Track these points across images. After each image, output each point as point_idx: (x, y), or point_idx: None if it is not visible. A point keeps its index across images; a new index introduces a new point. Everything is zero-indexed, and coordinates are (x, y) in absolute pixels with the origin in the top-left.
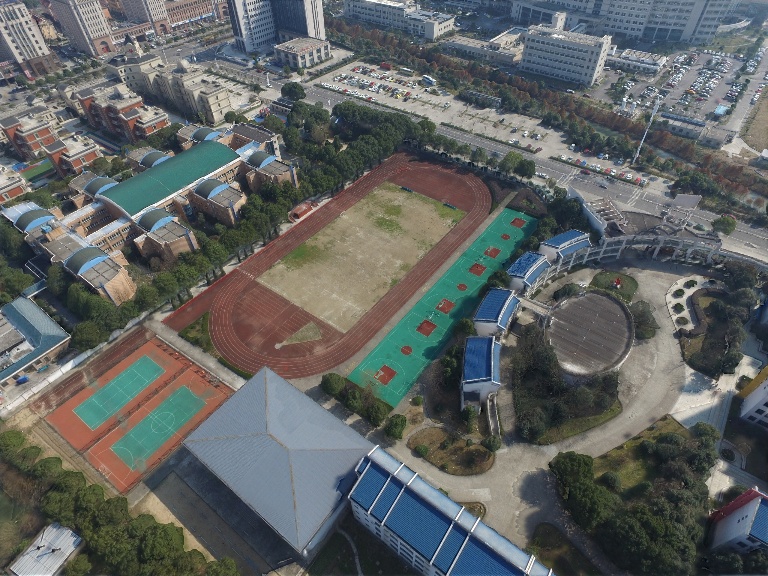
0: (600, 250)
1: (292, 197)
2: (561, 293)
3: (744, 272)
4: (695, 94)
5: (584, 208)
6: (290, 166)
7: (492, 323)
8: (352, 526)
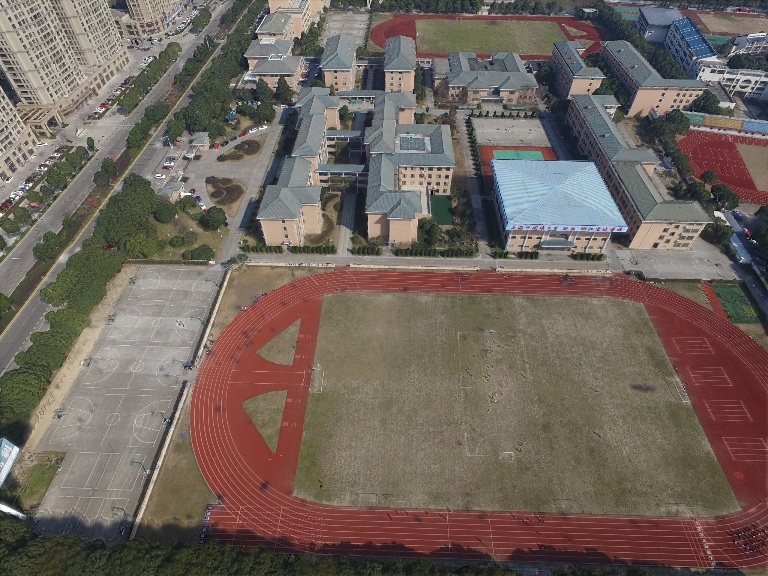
0: None
1: None
2: None
3: None
4: None
5: None
6: None
7: None
8: None
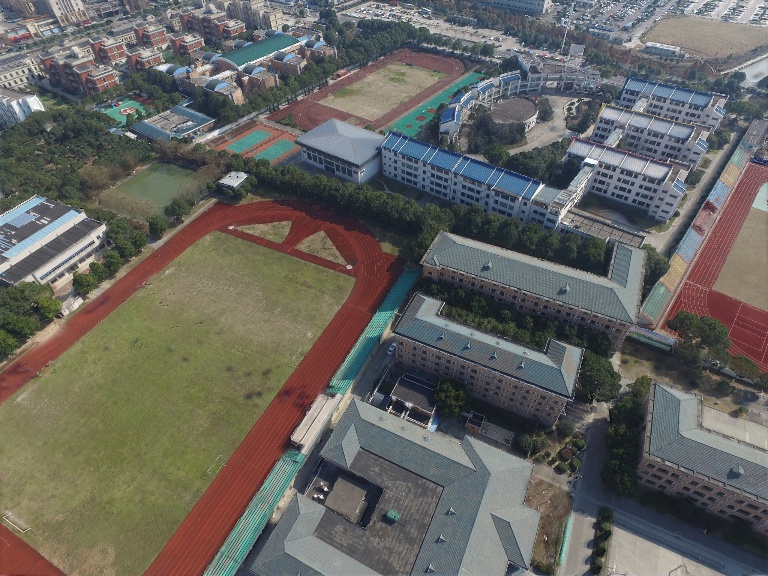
0: (527, 84)
1: (336, 63)
2: (500, 98)
3: (609, 88)
4: (616, 18)
5: (519, 61)
6: (333, 47)
7: (457, 103)
8: (382, 178)
